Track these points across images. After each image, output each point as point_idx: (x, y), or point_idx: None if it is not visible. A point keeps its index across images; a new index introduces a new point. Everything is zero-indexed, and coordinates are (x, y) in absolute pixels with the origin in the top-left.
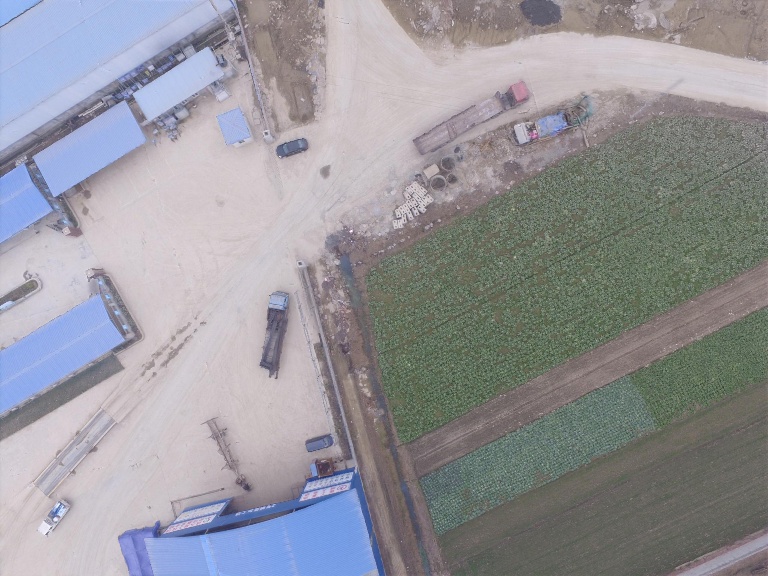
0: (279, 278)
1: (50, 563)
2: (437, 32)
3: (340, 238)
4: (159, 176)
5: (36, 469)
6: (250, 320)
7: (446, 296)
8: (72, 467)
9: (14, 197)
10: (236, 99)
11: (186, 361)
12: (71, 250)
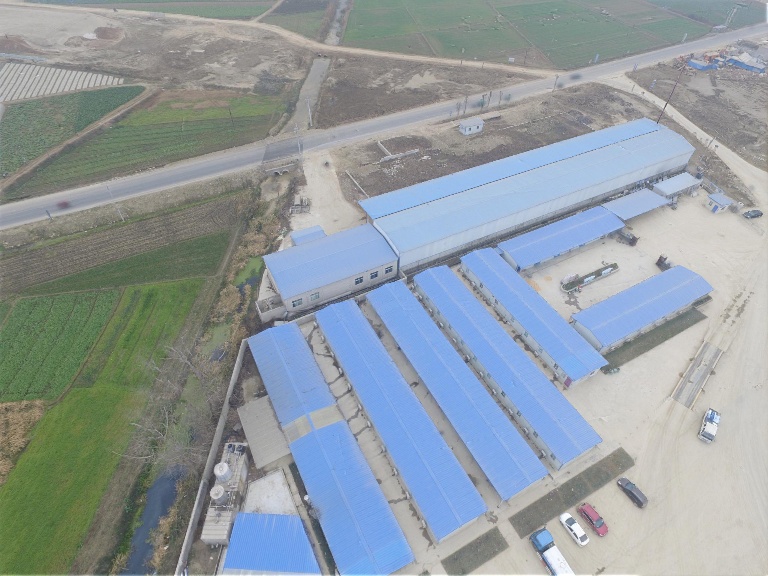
0: None
1: (720, 478)
2: None
3: None
4: (673, 223)
5: (665, 388)
6: None
7: None
8: (701, 384)
9: (602, 217)
10: (702, 197)
11: (754, 314)
12: (631, 253)
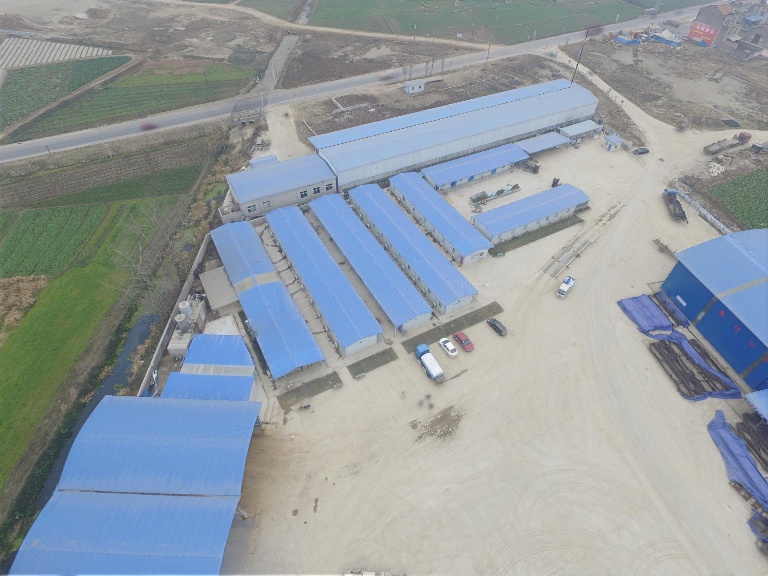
0: (660, 191)
1: (567, 319)
2: (688, 127)
3: (685, 179)
4: (573, 158)
5: (539, 265)
6: (653, 205)
7: (761, 199)
8: (567, 263)
9: (510, 150)
10: (602, 139)
11: (622, 219)
12: (533, 178)
